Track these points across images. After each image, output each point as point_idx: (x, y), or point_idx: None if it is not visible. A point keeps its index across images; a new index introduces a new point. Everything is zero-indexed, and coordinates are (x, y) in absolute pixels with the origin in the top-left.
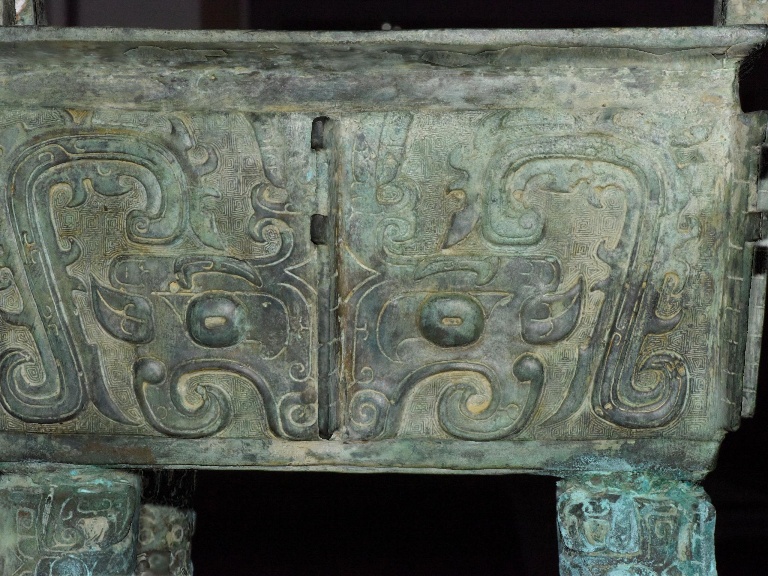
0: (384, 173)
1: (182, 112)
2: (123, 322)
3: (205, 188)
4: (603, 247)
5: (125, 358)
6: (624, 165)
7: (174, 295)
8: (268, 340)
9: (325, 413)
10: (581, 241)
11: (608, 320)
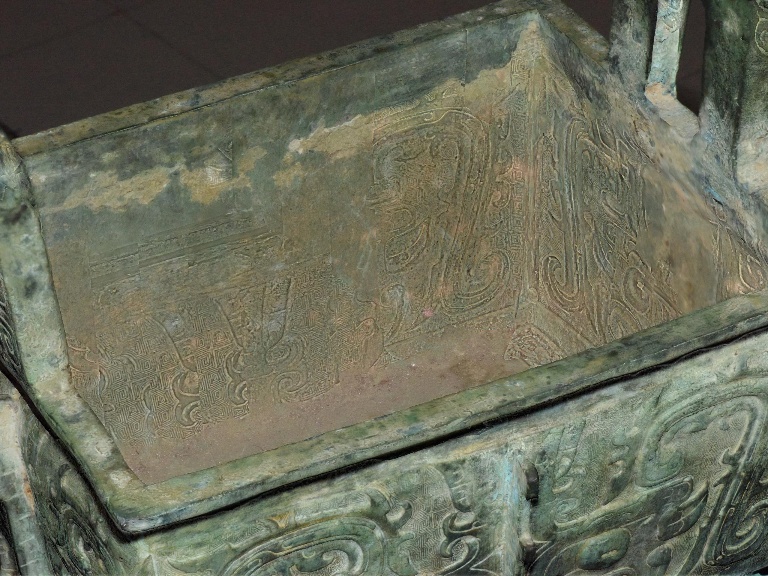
0: (559, 471)
1: (376, 482)
2: None
3: (403, 536)
4: (728, 455)
5: None
6: (753, 395)
7: None
8: None
9: None
10: (711, 457)
11: (724, 500)
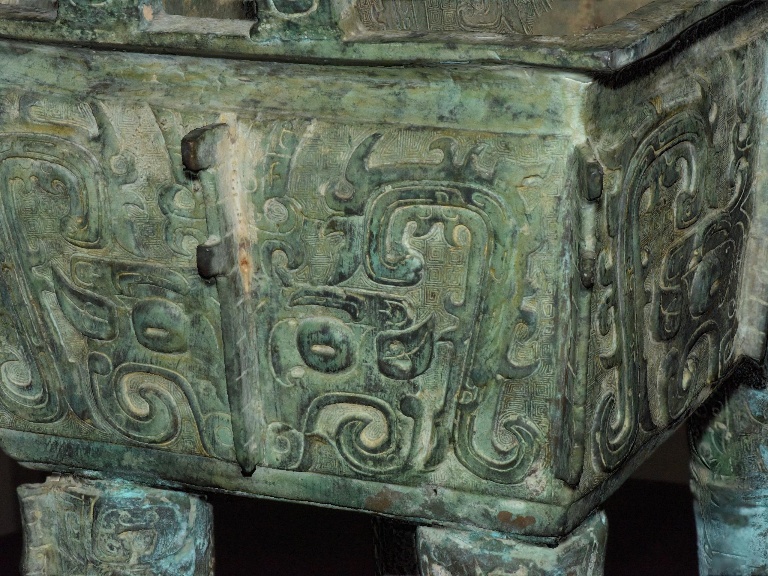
0: None
1: (699, 68)
2: (666, 321)
3: None
4: None
5: (658, 359)
6: None
7: None
8: None
9: (767, 341)
10: None
11: None
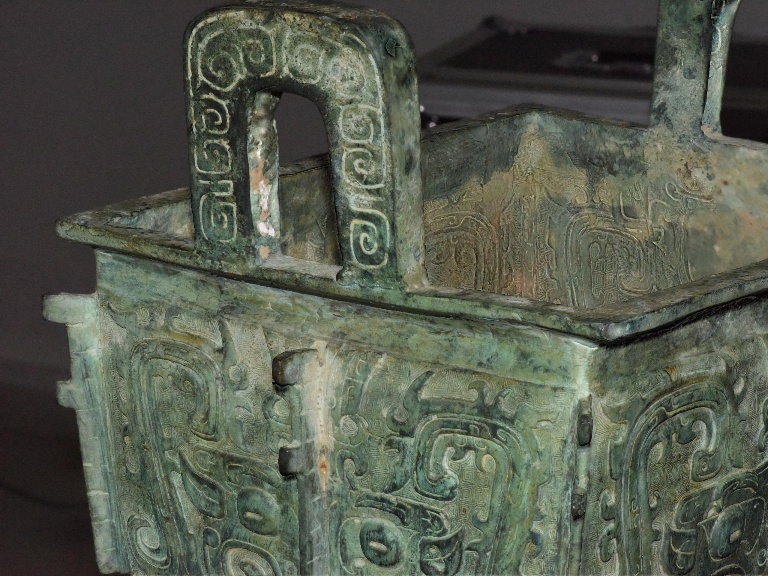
0: None
1: (727, 347)
2: (678, 559)
3: (741, 415)
4: None
5: None
6: None
7: (709, 520)
8: (751, 537)
9: None
10: None
11: None
